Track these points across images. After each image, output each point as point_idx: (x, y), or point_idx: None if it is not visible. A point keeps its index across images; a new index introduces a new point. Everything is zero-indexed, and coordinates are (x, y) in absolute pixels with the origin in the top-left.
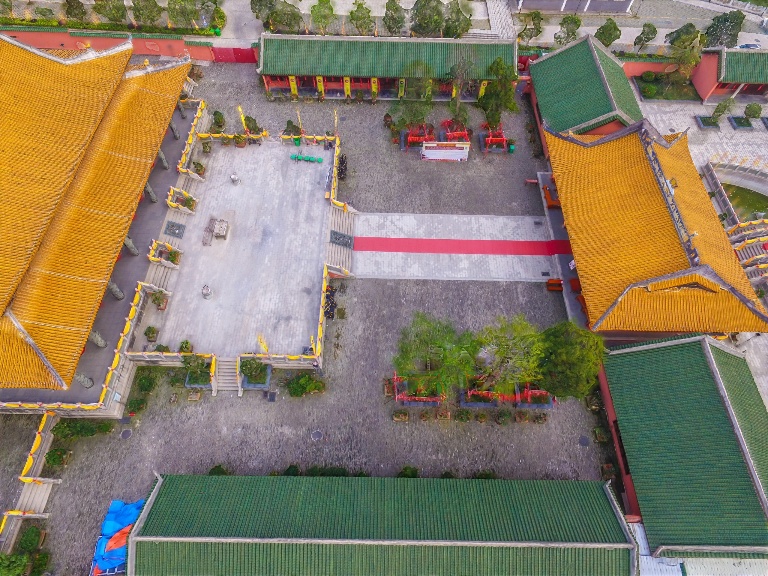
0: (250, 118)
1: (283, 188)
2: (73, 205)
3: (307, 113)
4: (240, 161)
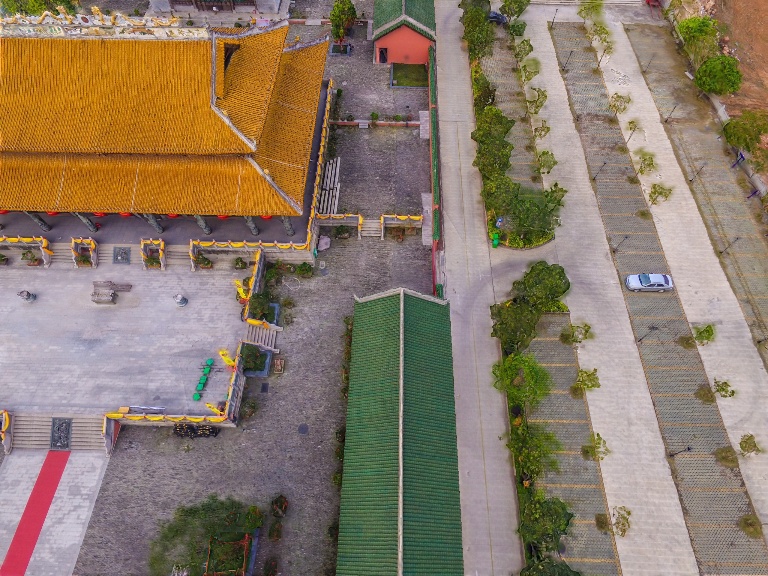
0: (258, 300)
1: (159, 355)
2: (65, 164)
3: (321, 375)
4: (218, 302)
